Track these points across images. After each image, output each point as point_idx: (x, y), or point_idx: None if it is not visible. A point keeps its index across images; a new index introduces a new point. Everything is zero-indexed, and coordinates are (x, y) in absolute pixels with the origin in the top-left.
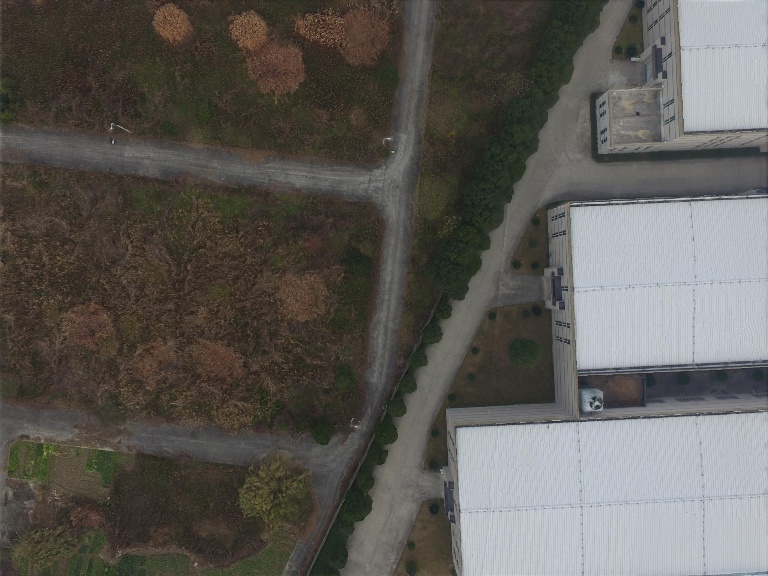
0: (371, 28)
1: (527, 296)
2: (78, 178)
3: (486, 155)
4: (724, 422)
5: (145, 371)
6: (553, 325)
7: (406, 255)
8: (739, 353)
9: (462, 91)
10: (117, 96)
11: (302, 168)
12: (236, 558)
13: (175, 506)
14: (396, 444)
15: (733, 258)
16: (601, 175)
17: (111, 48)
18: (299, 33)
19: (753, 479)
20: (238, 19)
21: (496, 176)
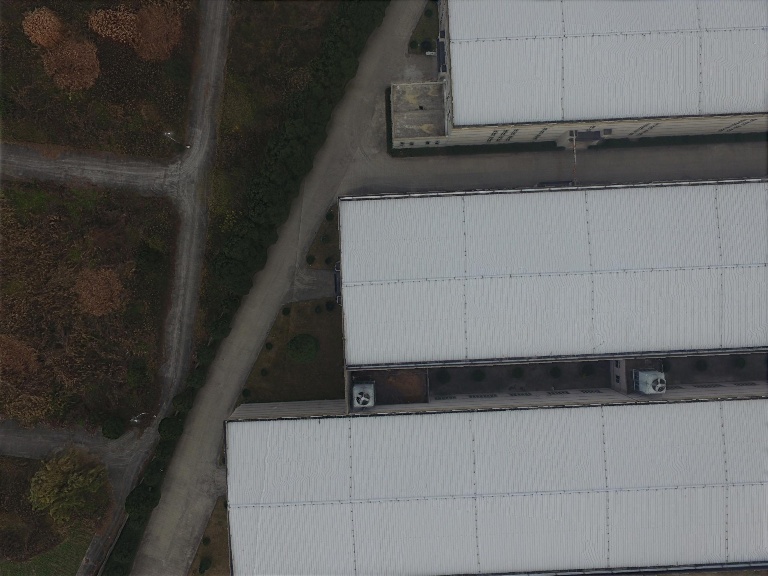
0: (165, 24)
1: (322, 291)
2: None
3: (264, 149)
4: (498, 419)
5: None
6: None
7: (201, 250)
8: (517, 349)
9: (253, 86)
10: None
11: (98, 163)
12: (33, 551)
13: None
14: (191, 439)
15: (505, 253)
16: (397, 170)
17: None
18: (92, 29)
19: (526, 477)
20: (29, 15)
21: (268, 170)
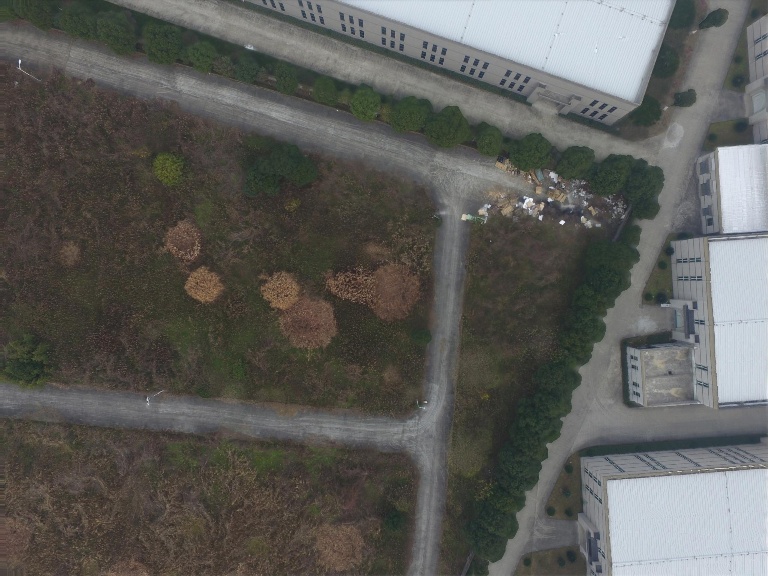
0: (401, 282)
1: (561, 540)
2: (114, 440)
3: (521, 423)
4: None
5: None
6: (588, 570)
7: (441, 503)
8: None
9: (494, 345)
10: (150, 356)
11: (336, 421)
12: None
13: None
14: None
15: None
16: (633, 420)
17: (144, 312)
18: (330, 292)
19: None
20: (270, 283)
21: (532, 450)
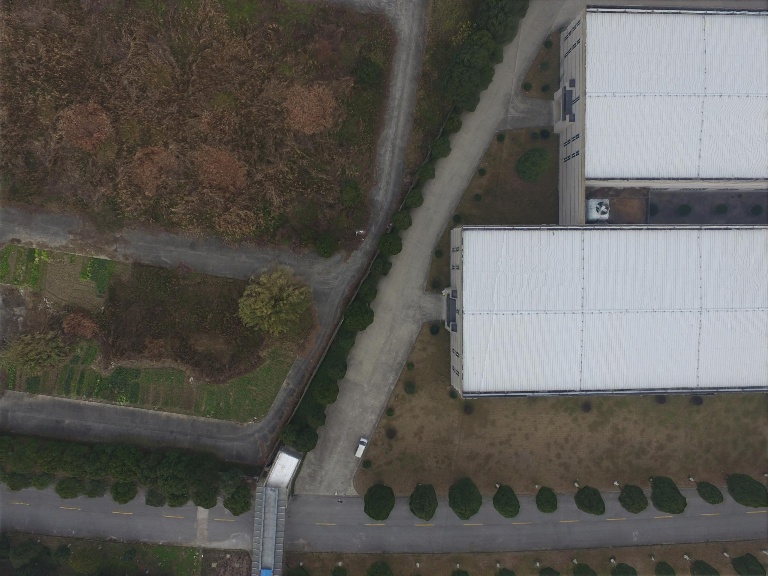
0: None
1: (536, 120)
2: None
3: None
4: (724, 237)
5: (144, 177)
6: (561, 150)
7: (417, 72)
8: (742, 172)
9: None
10: None
11: None
12: (233, 373)
13: (172, 318)
14: (399, 264)
15: (743, 72)
16: (615, 1)
17: None
18: None
19: (749, 293)
20: None
21: None
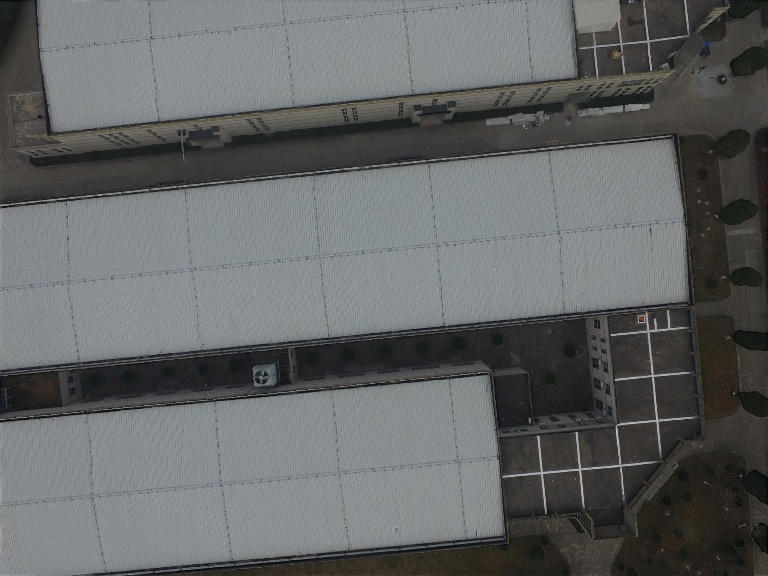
0: None
1: None
2: None
3: None
4: (114, 419)
5: None
6: None
7: None
8: (134, 349)
9: None
10: None
11: None
12: None
13: None
14: None
15: (107, 255)
16: (40, 179)
17: None
18: None
19: (142, 475)
20: None
21: None
